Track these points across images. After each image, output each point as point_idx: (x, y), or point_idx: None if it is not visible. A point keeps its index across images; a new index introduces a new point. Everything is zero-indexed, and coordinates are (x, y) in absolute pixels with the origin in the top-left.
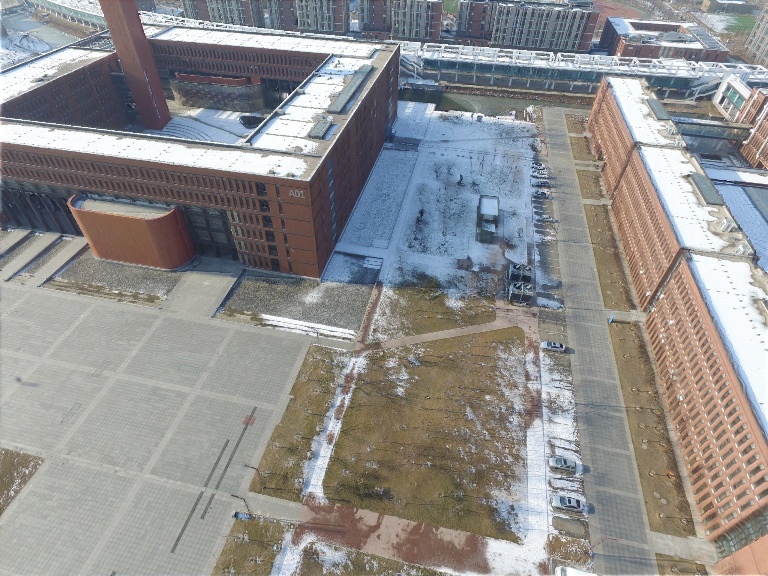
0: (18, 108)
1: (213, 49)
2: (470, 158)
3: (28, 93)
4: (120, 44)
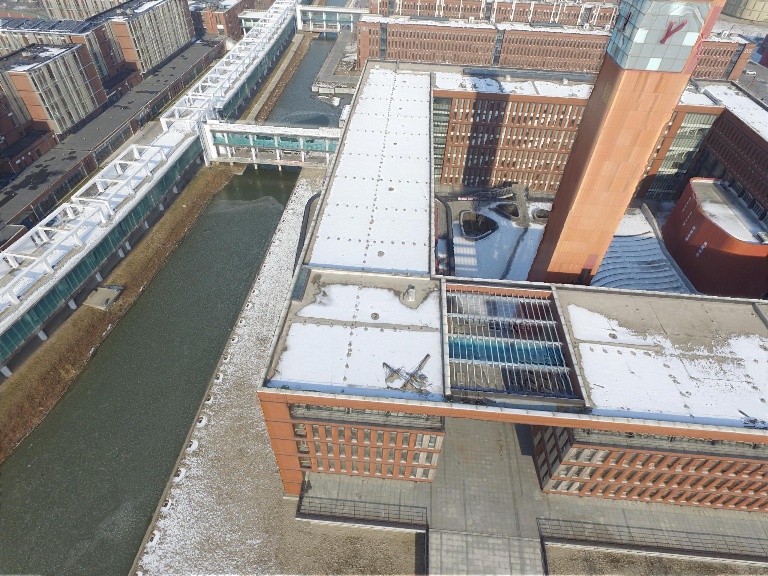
0: None
1: None
2: None
3: None
4: None
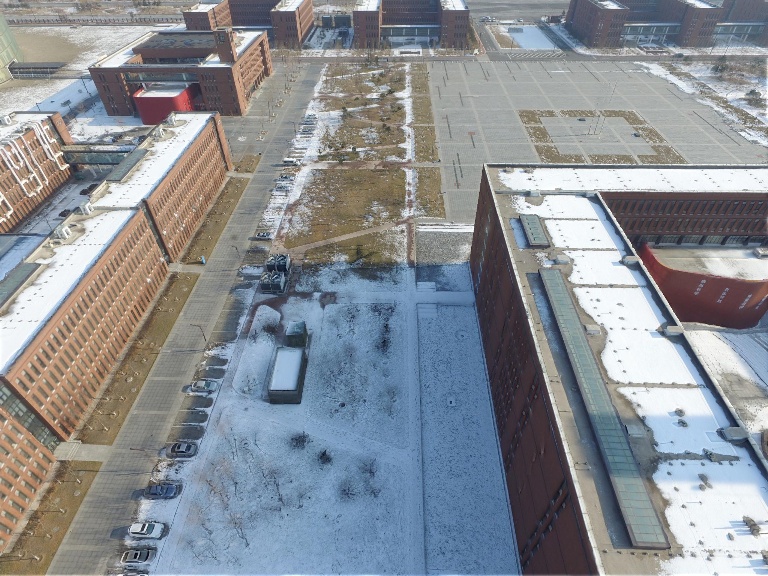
0: None
1: None
2: None
3: None
4: None
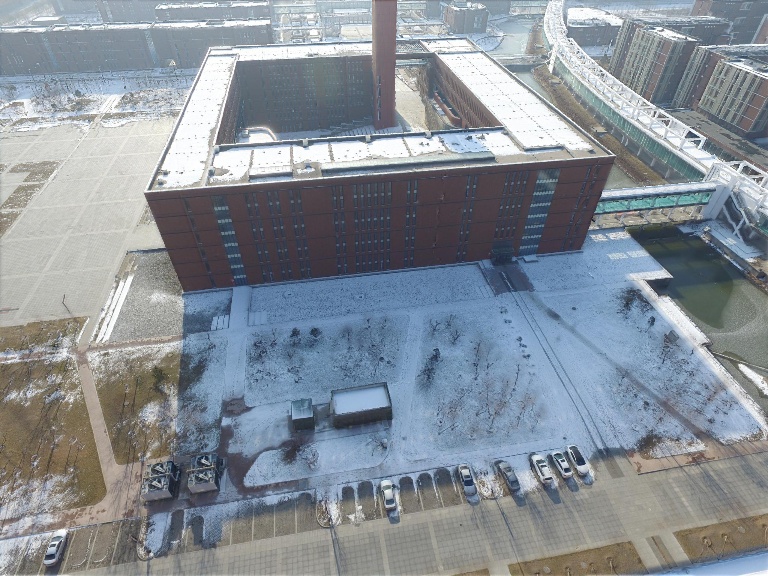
0: (270, 67)
1: (454, 79)
2: (479, 344)
3: (283, 60)
4: (373, 47)
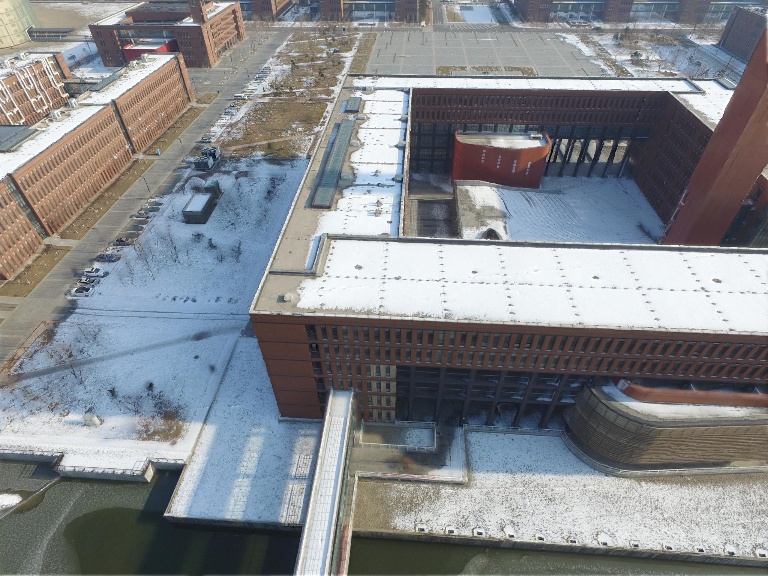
0: None
1: None
2: None
3: None
4: None
